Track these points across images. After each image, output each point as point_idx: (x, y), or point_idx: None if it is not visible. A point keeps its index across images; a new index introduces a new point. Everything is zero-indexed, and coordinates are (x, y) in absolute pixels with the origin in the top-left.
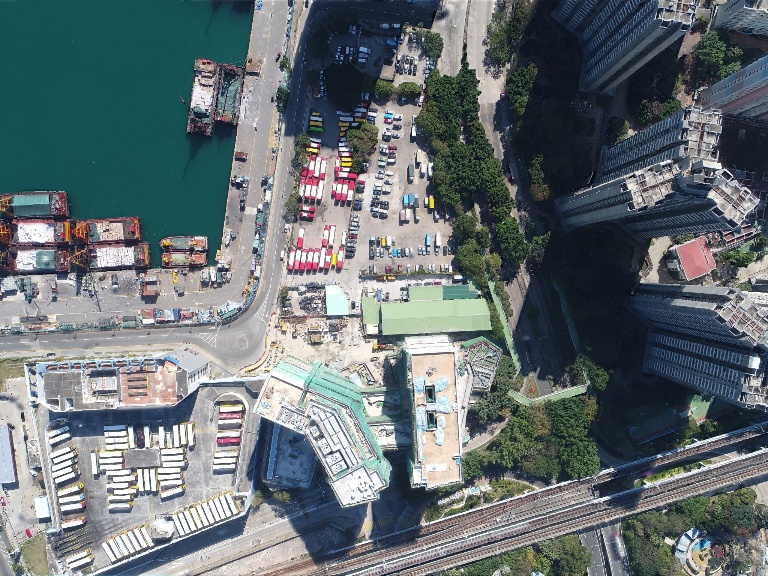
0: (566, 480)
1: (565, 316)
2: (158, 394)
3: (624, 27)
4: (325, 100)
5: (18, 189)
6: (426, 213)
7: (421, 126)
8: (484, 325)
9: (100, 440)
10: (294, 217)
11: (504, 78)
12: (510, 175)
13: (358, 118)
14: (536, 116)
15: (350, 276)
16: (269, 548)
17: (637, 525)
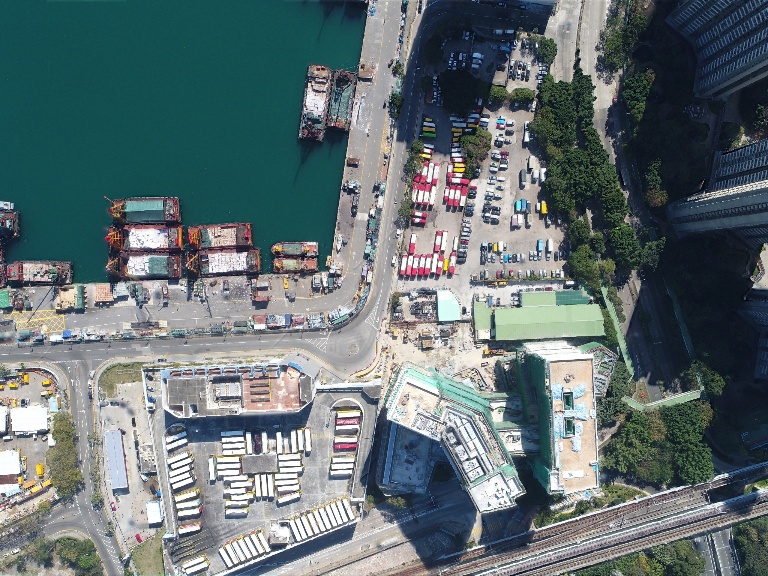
0: (679, 485)
1: (678, 321)
2: (280, 400)
3: (759, 34)
4: (438, 106)
5: (130, 195)
6: (537, 218)
7: (536, 132)
8: (597, 331)
9: (216, 446)
10: (405, 223)
11: (616, 84)
12: (622, 180)
13: (471, 124)
14: (654, 122)
15: (461, 281)
16: (379, 553)
17: (751, 530)
